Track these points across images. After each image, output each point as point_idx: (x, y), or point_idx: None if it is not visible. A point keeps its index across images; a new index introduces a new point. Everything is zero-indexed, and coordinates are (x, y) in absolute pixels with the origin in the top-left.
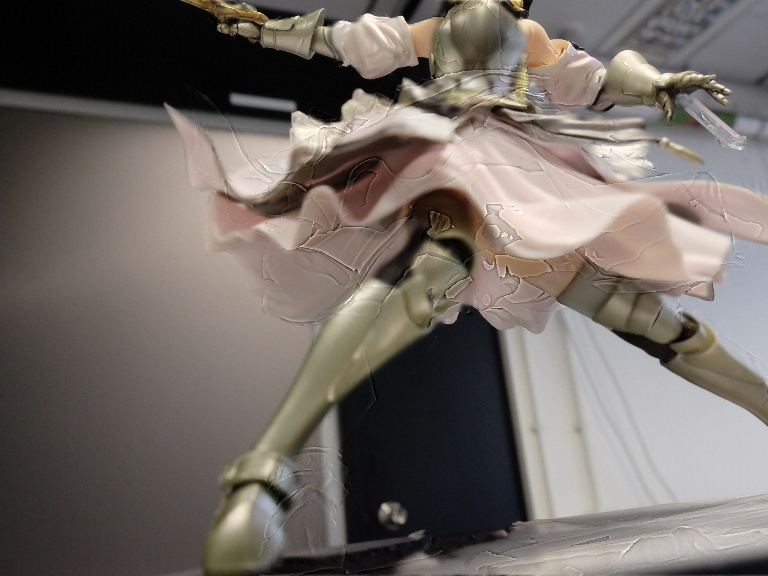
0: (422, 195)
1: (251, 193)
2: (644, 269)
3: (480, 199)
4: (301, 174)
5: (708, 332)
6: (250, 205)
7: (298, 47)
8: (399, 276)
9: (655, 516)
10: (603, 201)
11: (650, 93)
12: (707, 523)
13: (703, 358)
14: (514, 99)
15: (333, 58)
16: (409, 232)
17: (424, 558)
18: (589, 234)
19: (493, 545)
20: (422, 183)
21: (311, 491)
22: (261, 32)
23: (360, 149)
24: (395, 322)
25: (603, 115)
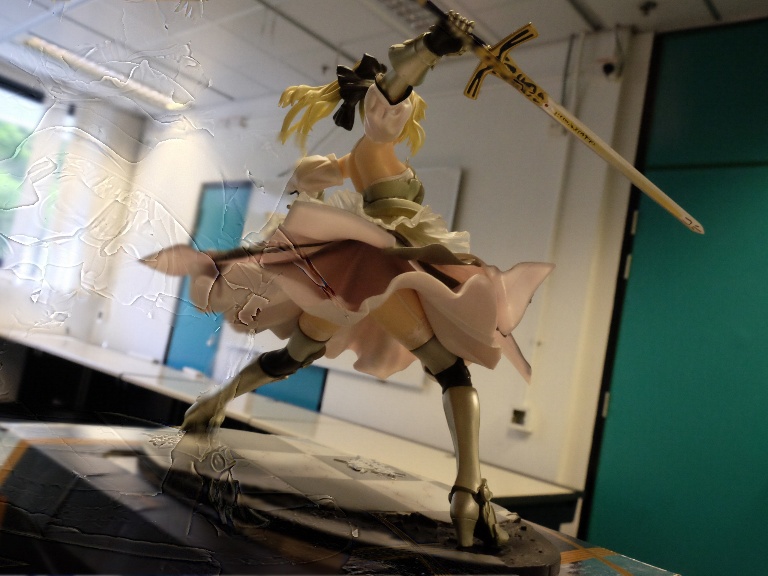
0: None
1: None
2: None
3: None
4: None
5: None
6: None
7: None
8: None
9: None
10: None
11: None
12: None
13: None
14: None
15: None
16: None
17: None
18: None
19: None
20: None
21: None
22: None
23: None
24: None
25: None
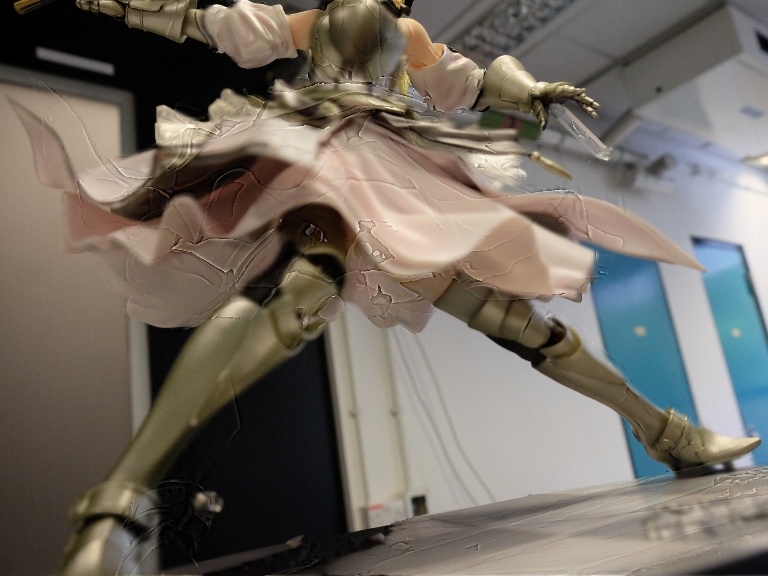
0: (291, 210)
1: (108, 195)
2: (515, 282)
3: (353, 213)
4: (162, 180)
5: (574, 337)
6: (107, 209)
7: (167, 31)
8: (277, 276)
9: (524, 513)
10: (476, 216)
11: (526, 101)
12: (567, 536)
13: (570, 361)
14: None
15: (206, 45)
16: (287, 232)
17: (298, 571)
18: (461, 251)
19: (370, 549)
20: (292, 196)
21: (168, 529)
22: (126, 11)
23: (227, 156)
24: (262, 344)
25: (479, 125)
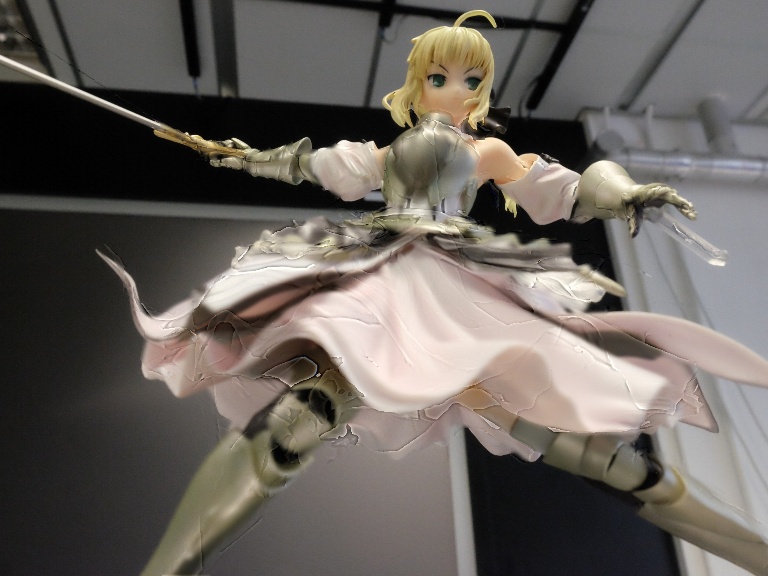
0: (263, 349)
1: (165, 333)
2: (546, 418)
3: (340, 348)
4: (182, 321)
5: (678, 479)
6: (161, 345)
7: (276, 176)
8: None
9: None
10: (480, 346)
11: (620, 207)
12: None
13: (679, 509)
14: (442, 227)
15: (310, 184)
16: None
17: None
18: None
19: None
20: (276, 333)
21: None
22: (243, 165)
23: (230, 297)
24: (230, 482)
25: (523, 243)
